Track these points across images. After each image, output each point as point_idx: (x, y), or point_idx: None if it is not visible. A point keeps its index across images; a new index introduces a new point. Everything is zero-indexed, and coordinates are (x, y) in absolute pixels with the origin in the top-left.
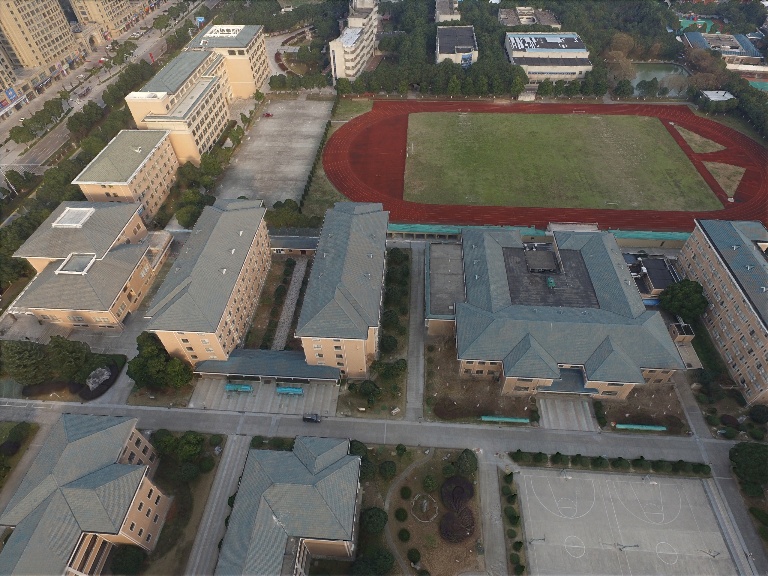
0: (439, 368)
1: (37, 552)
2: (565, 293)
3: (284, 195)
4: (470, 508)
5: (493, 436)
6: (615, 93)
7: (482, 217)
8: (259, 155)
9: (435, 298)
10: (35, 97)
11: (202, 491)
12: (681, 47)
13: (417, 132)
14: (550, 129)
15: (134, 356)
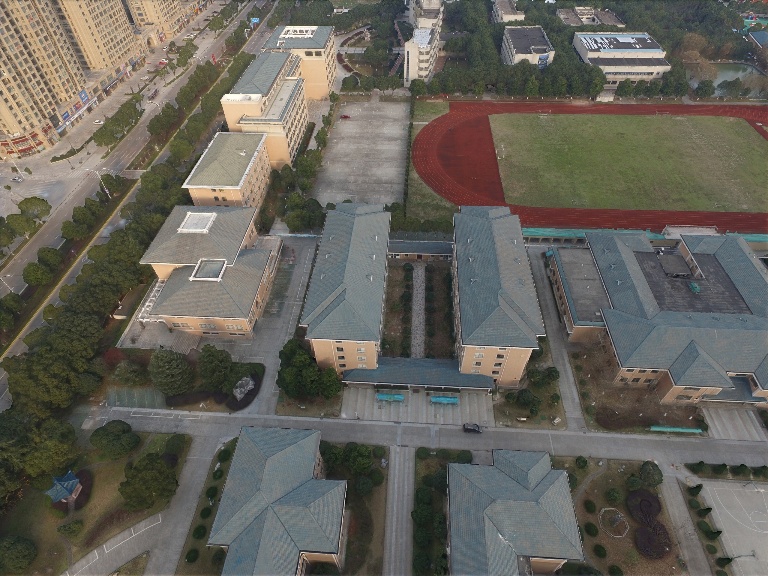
0: (590, 376)
1: (266, 574)
2: (711, 298)
3: (383, 198)
4: (661, 522)
5: (664, 447)
6: (696, 93)
7: (592, 220)
8: (347, 157)
9: (578, 304)
10: (103, 99)
11: (378, 505)
12: (751, 47)
13: (502, 134)
14: (637, 130)
15: (271, 364)
